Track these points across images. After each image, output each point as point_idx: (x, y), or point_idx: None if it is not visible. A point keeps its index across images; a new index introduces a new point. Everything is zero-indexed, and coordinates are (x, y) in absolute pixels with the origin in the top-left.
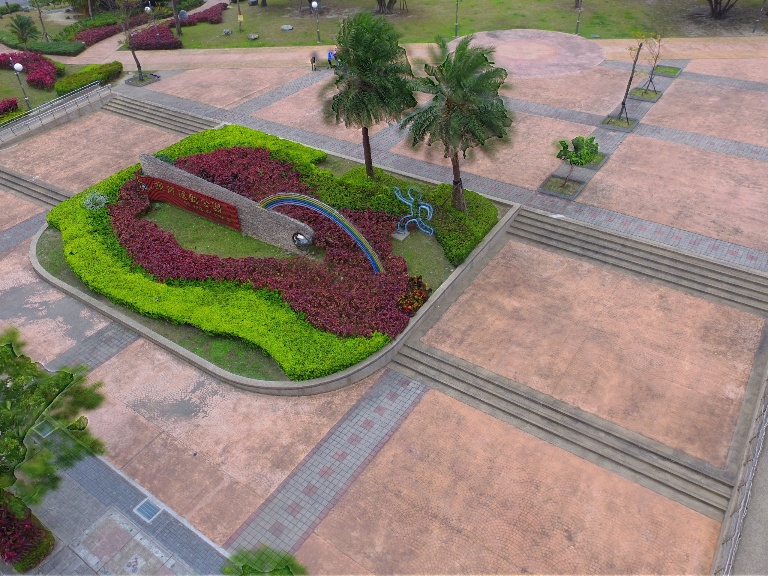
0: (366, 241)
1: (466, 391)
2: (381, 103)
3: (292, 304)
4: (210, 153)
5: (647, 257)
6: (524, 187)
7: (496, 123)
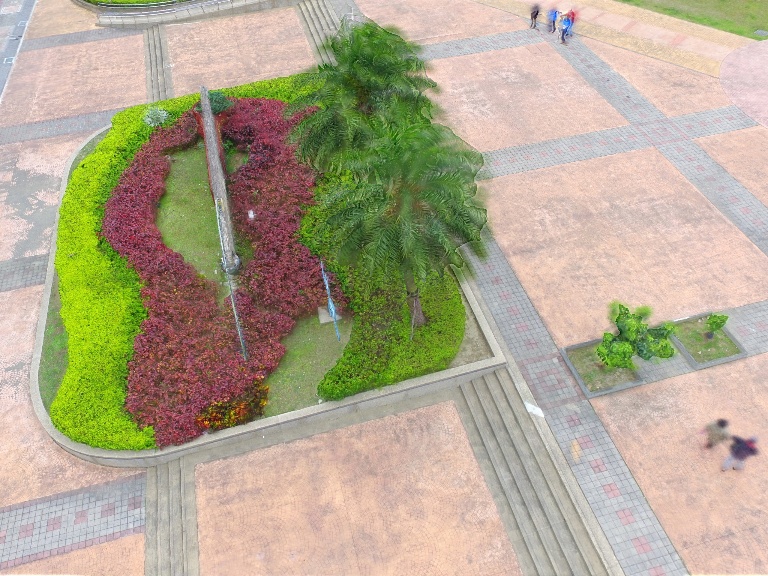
0: (235, 312)
1: (160, 568)
2: (350, 147)
3: (137, 336)
4: (288, 105)
5: (575, 569)
6: (552, 334)
7: (416, 258)
